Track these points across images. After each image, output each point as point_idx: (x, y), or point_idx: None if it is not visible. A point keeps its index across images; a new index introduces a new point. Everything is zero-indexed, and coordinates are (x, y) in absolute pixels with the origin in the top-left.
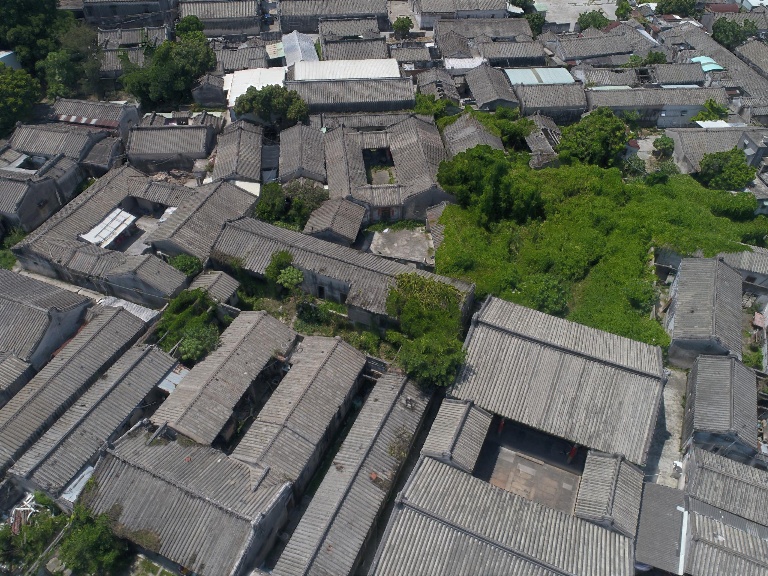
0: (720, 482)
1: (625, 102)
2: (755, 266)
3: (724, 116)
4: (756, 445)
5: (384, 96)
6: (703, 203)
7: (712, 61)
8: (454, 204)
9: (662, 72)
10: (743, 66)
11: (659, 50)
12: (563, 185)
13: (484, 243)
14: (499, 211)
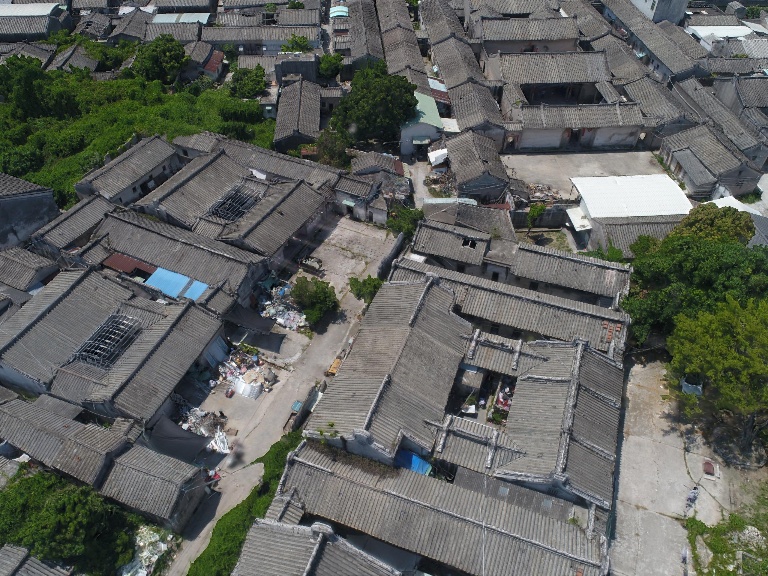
0: (2, 262)
1: (229, 37)
2: (197, 145)
3: (309, 49)
4: (62, 246)
5: (21, 29)
6: (215, 107)
7: (344, 10)
8: (2, 102)
9: (284, 16)
10: (361, 13)
11: (314, 2)
12: (107, 92)
13: (2, 128)
14: (45, 110)
